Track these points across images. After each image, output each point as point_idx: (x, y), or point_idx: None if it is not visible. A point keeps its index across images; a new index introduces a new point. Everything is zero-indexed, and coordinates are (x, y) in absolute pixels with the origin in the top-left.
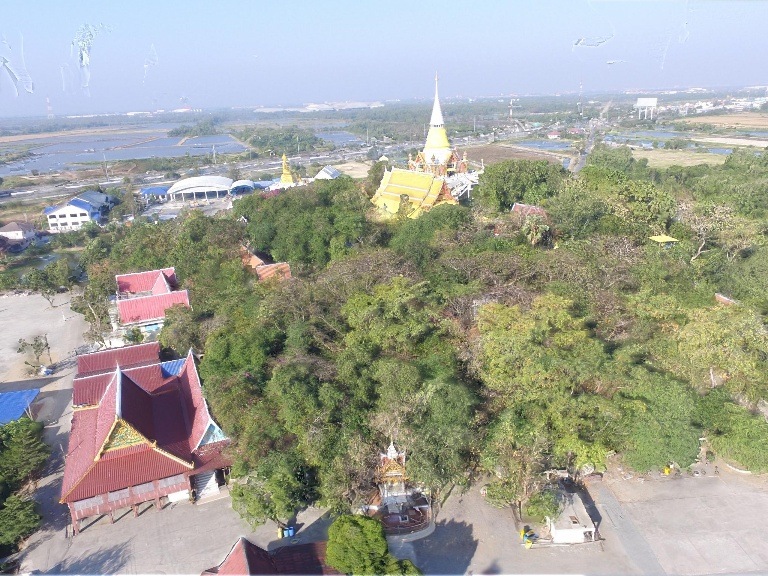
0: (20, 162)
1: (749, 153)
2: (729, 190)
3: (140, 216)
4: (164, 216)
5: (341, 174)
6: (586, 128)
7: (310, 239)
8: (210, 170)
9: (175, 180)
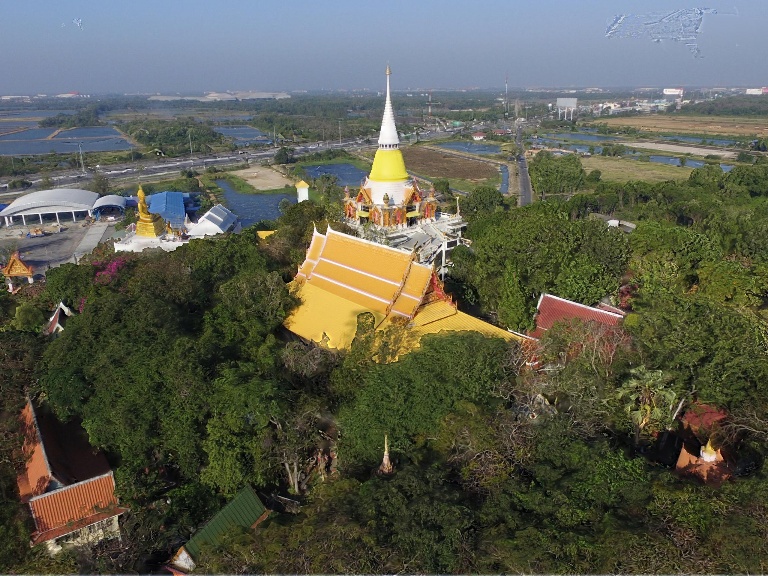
0: None
1: (717, 168)
2: (761, 231)
3: None
4: None
5: (243, 184)
6: (512, 129)
7: (163, 414)
8: (67, 181)
9: (24, 190)
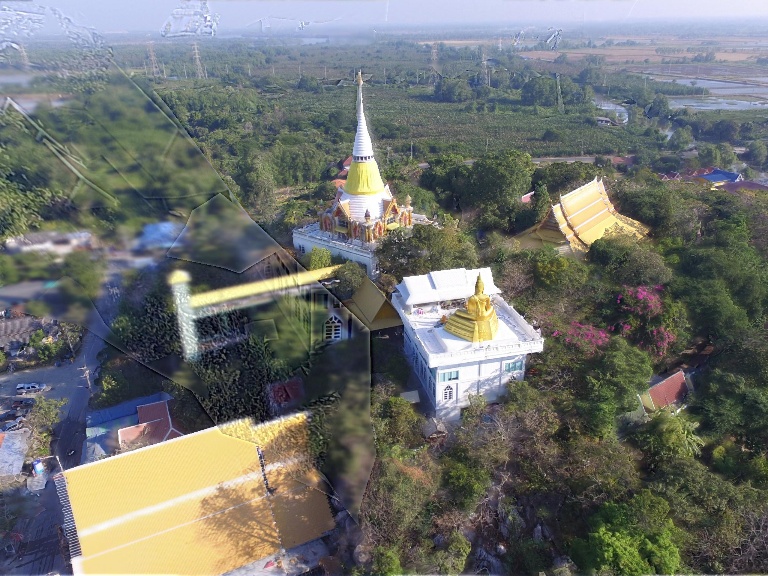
0: None
1: None
2: None
3: None
4: None
5: None
6: None
7: None
8: None
9: None
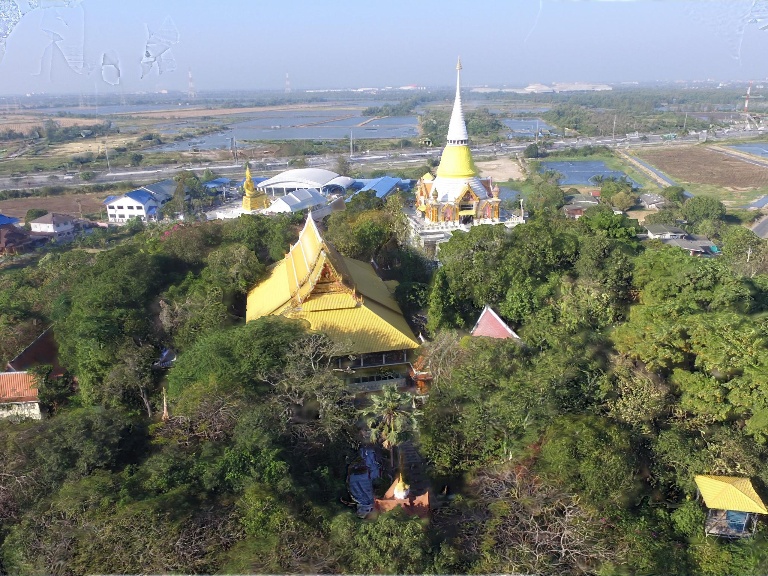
0: (208, 136)
1: None
2: None
3: (190, 215)
4: (215, 217)
5: None
6: None
7: None
8: (317, 162)
9: None
